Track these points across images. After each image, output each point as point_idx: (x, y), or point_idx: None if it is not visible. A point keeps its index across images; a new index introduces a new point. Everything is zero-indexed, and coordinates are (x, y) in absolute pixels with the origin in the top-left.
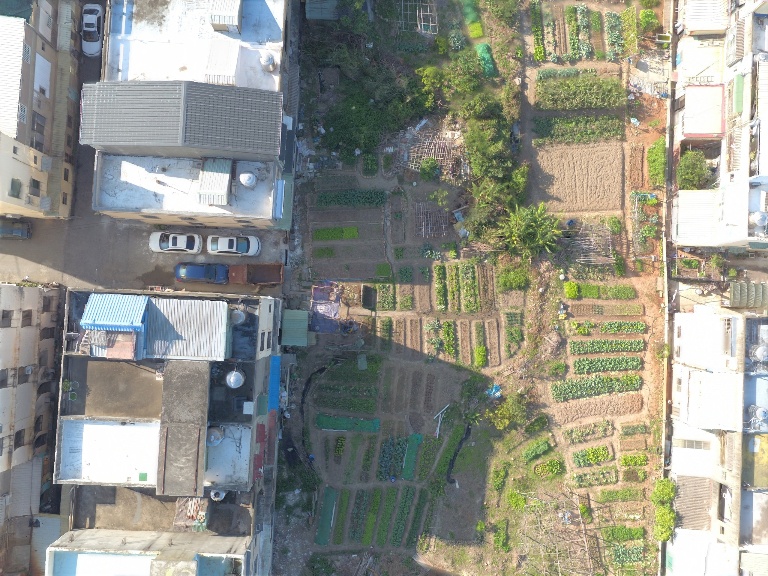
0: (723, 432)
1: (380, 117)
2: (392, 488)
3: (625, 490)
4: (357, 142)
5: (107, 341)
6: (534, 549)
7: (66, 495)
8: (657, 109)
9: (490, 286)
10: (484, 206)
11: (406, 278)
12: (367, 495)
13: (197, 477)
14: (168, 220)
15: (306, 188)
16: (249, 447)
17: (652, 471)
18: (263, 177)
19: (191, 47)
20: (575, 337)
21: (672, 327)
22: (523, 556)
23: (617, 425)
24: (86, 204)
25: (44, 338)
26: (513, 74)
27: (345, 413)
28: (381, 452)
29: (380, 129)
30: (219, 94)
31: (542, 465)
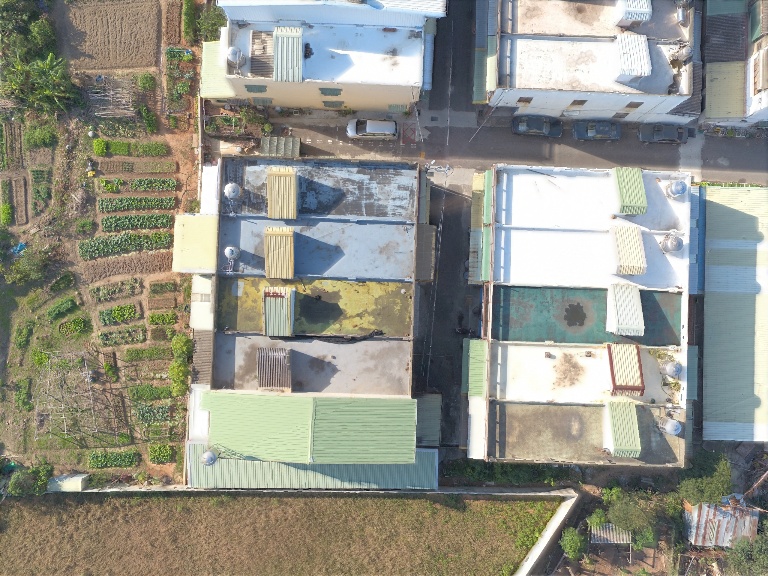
0: None
1: None
2: None
3: (152, 349)
4: None
5: None
6: (56, 408)
7: None
8: None
9: (17, 144)
10: None
11: None
12: None
13: None
14: None
15: None
16: None
17: (182, 330)
18: None
19: None
20: (105, 195)
21: None
22: (45, 415)
23: (146, 283)
24: None
25: None
26: None
27: None
28: None
29: None
30: None
31: (67, 324)
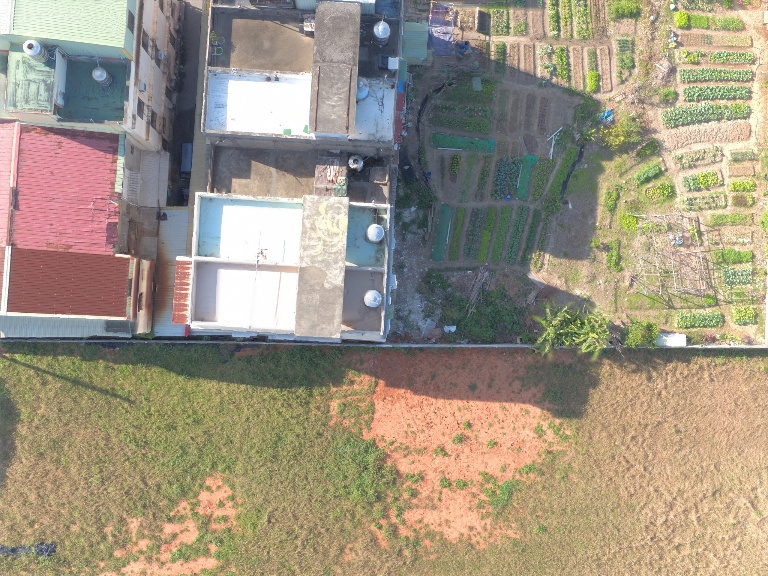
0: None
1: None
2: (507, 207)
3: (734, 214)
4: None
5: None
6: (646, 269)
7: (195, 186)
8: None
9: (602, 14)
10: None
11: (520, 3)
12: (482, 213)
13: (349, 115)
14: None
15: None
16: (391, 107)
17: (760, 197)
18: None
19: None
20: (685, 66)
21: None
22: None
23: (726, 152)
24: None
25: (169, 39)
26: None
27: (460, 133)
28: (496, 171)
29: None
30: None
31: (653, 189)
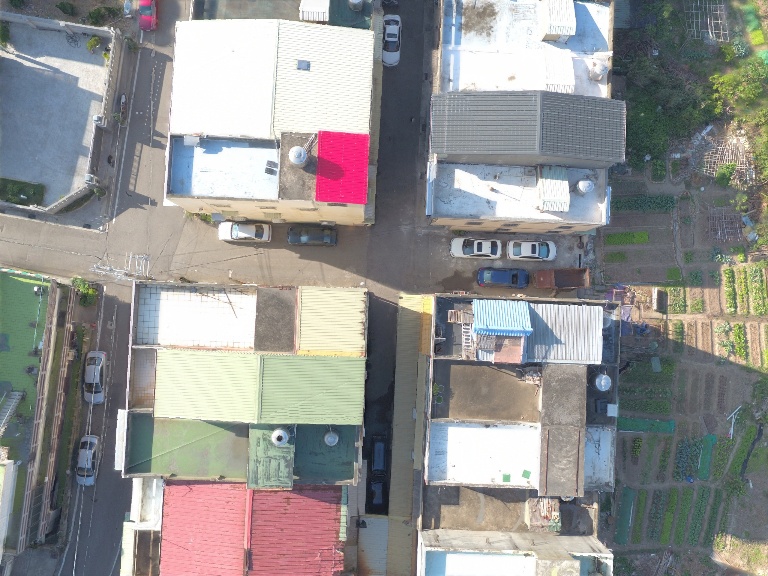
0: None
1: (669, 123)
2: (688, 488)
3: None
4: (648, 148)
5: (495, 346)
6: None
7: (394, 496)
8: None
9: None
10: None
11: (697, 282)
12: (664, 495)
13: (578, 478)
14: (484, 226)
15: None
16: (608, 448)
17: None
18: None
19: (520, 57)
20: None
21: None
22: None
23: None
24: (386, 211)
25: None
26: None
27: (641, 415)
28: (677, 453)
29: (668, 135)
30: (570, 103)
31: None
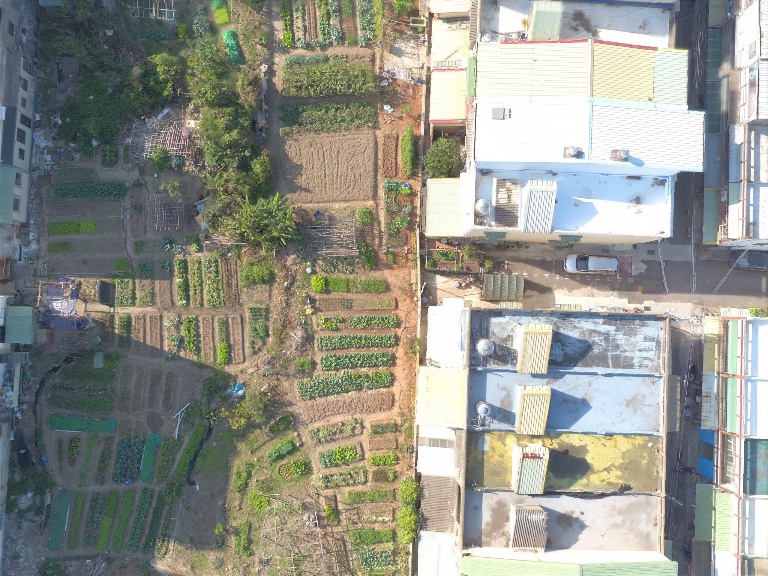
0: None
1: (118, 107)
2: (129, 490)
3: (374, 491)
4: (93, 133)
5: None
6: None
7: None
8: (412, 95)
9: (234, 280)
10: (224, 197)
11: (145, 273)
12: (102, 498)
13: None
14: None
15: (43, 181)
16: None
17: (403, 471)
18: None
19: None
20: (323, 332)
21: None
22: (266, 560)
23: (367, 423)
24: None
25: None
26: (260, 61)
27: (80, 413)
28: (117, 453)
29: (119, 119)
30: None
31: (287, 465)
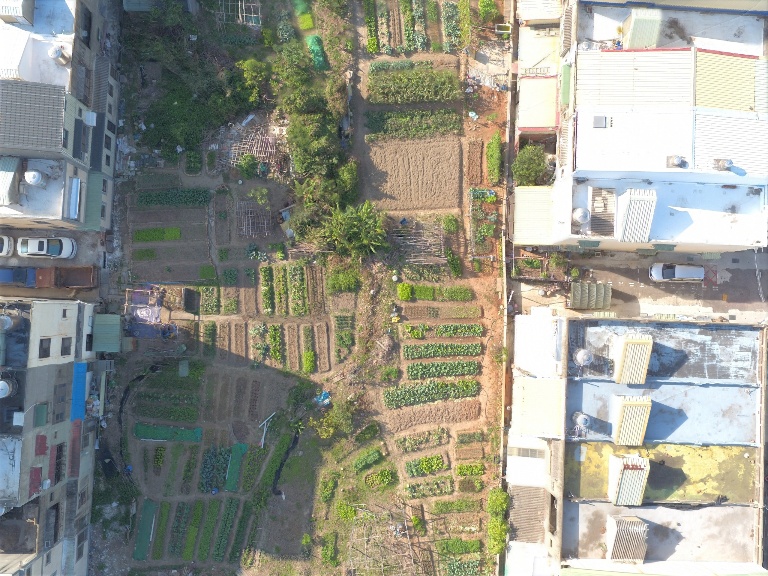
0: (551, 440)
1: (203, 113)
2: (214, 500)
3: (461, 501)
4: (178, 139)
5: None
6: (364, 563)
7: None
8: (497, 102)
9: (319, 288)
10: (311, 205)
11: (230, 280)
12: (188, 508)
13: None
14: None
15: (127, 187)
16: None
17: (490, 481)
18: (56, 175)
19: None
20: (409, 341)
21: (513, 330)
22: None
23: (453, 433)
24: None
25: None
26: (344, 67)
27: (165, 422)
28: (202, 463)
29: (204, 125)
30: None
31: (373, 475)
